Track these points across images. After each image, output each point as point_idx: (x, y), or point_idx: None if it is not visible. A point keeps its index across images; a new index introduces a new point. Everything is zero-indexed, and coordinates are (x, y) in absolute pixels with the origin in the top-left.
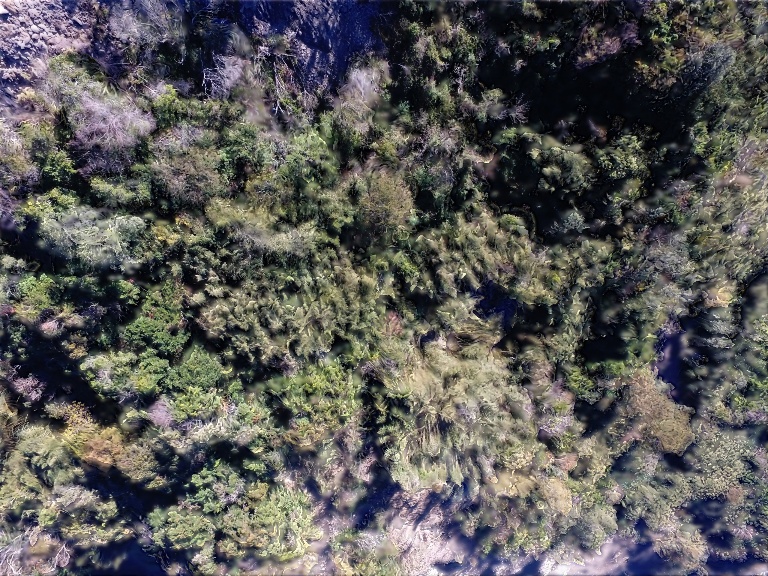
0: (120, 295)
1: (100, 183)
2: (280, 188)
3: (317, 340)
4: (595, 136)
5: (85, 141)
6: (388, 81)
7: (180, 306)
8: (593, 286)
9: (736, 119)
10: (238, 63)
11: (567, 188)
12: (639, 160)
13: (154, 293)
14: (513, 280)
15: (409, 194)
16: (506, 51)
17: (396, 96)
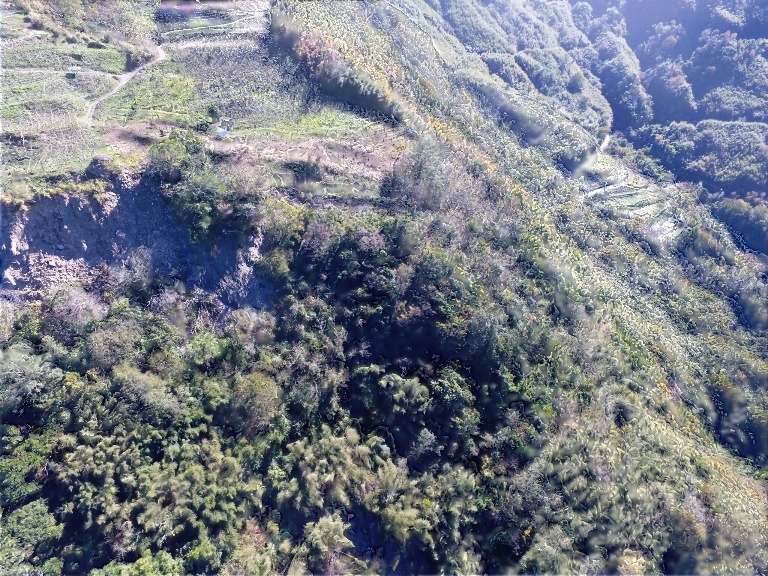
0: (4, 435)
1: (49, 340)
2: (175, 362)
3: (164, 509)
4: (423, 367)
5: (57, 312)
6: (272, 324)
7: (50, 450)
8: (473, 524)
9: (529, 366)
10: (174, 294)
11: (415, 410)
12: (459, 381)
13: (35, 430)
14: (381, 496)
15: (273, 379)
16: (352, 316)
17: (280, 339)
